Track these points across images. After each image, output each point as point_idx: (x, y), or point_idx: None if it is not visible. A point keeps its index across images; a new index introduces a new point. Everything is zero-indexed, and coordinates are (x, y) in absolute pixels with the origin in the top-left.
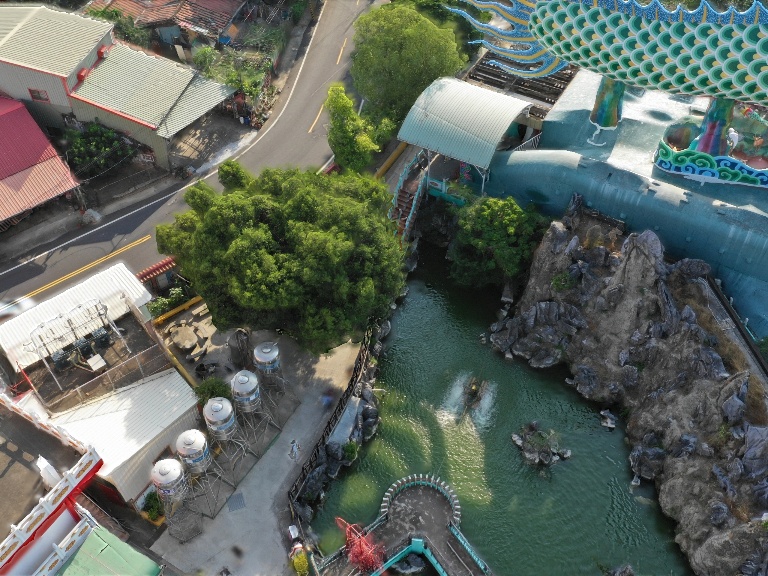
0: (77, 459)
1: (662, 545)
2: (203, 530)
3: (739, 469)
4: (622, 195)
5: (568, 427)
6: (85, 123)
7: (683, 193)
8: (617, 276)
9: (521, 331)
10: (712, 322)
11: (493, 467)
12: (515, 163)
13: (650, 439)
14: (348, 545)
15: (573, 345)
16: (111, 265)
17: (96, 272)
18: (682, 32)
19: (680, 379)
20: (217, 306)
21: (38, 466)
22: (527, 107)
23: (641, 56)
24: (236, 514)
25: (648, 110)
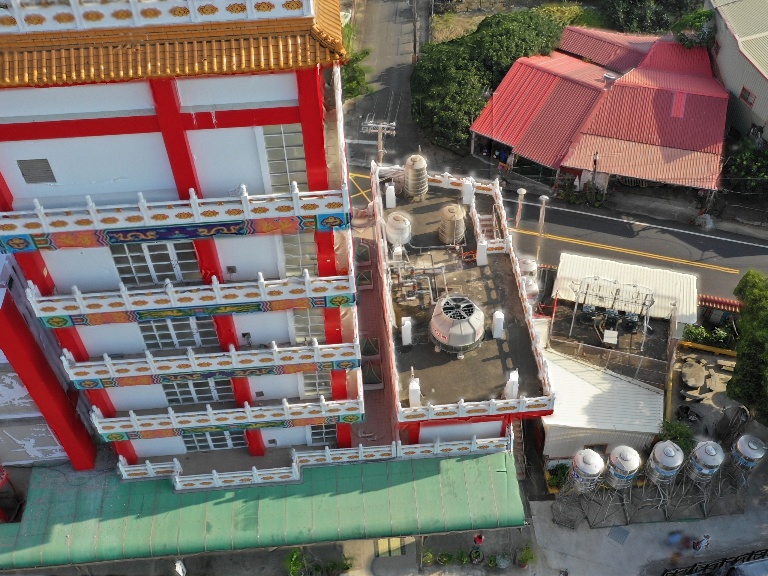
0: (538, 394)
1: None
2: (577, 528)
3: None
4: None
5: None
6: (766, 143)
7: None
8: None
9: None
10: None
11: None
12: None
13: None
14: None
15: None
16: (686, 271)
17: (670, 267)
18: None
19: None
20: (743, 374)
21: (510, 376)
22: None
23: None
24: (611, 542)
25: None
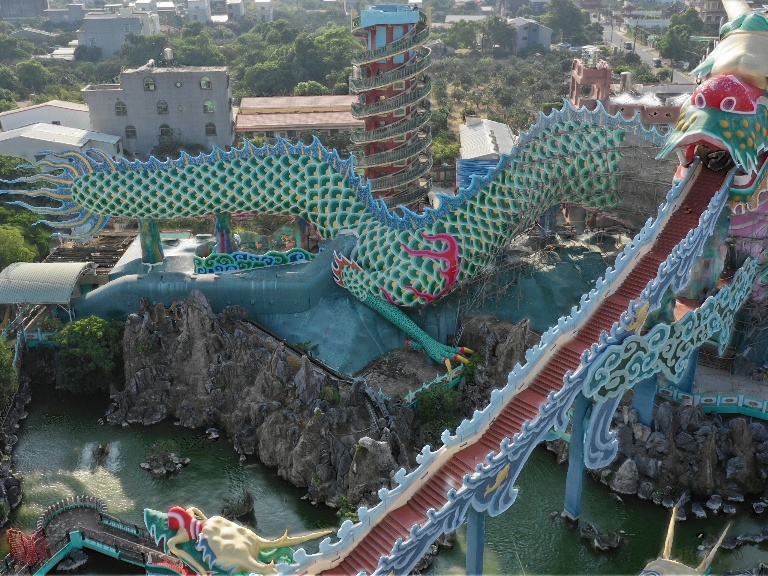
0: None
1: (274, 491)
2: None
3: (298, 403)
4: (174, 287)
5: (184, 449)
6: None
7: (215, 274)
8: (184, 330)
9: (129, 403)
10: (259, 340)
11: (130, 488)
12: (91, 296)
13: (242, 425)
14: (12, 551)
15: (172, 397)
16: None
17: None
18: (176, 173)
19: (248, 377)
20: None
21: None
22: (93, 267)
23: (155, 193)
24: None
25: (183, 249)
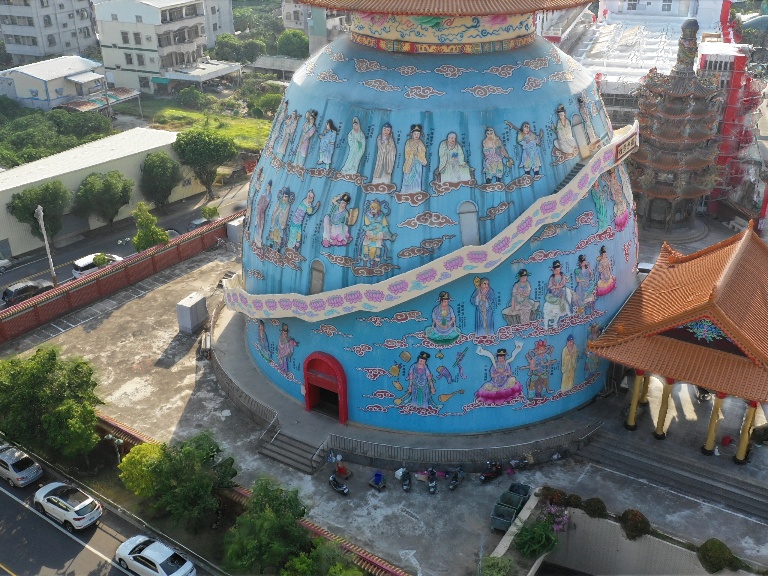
0: None
1: None
2: None
3: None
4: None
5: None
6: None
7: None
8: None
9: None
10: None
11: None
12: (746, 23)
13: None
14: None
15: None
16: None
17: None
18: None
19: None
20: None
21: None
22: None
23: None
24: None
25: None
